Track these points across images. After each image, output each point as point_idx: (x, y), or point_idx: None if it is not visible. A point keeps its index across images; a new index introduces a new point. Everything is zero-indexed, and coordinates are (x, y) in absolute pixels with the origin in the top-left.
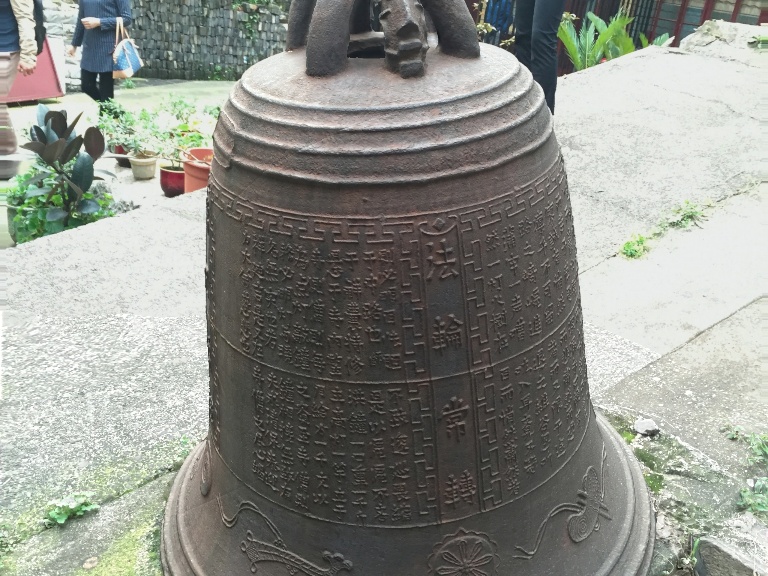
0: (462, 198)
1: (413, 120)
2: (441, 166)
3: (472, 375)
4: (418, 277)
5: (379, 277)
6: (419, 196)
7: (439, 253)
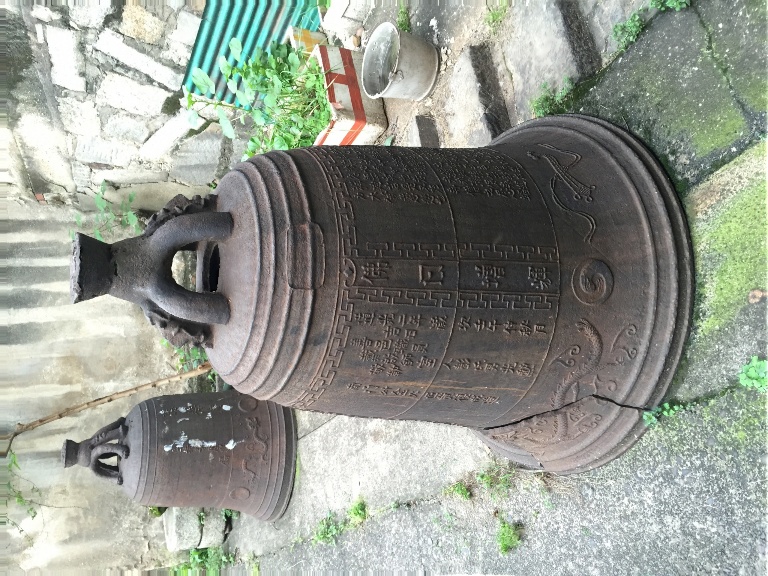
0: None
1: None
2: None
3: None
4: None
5: None
6: None
7: None
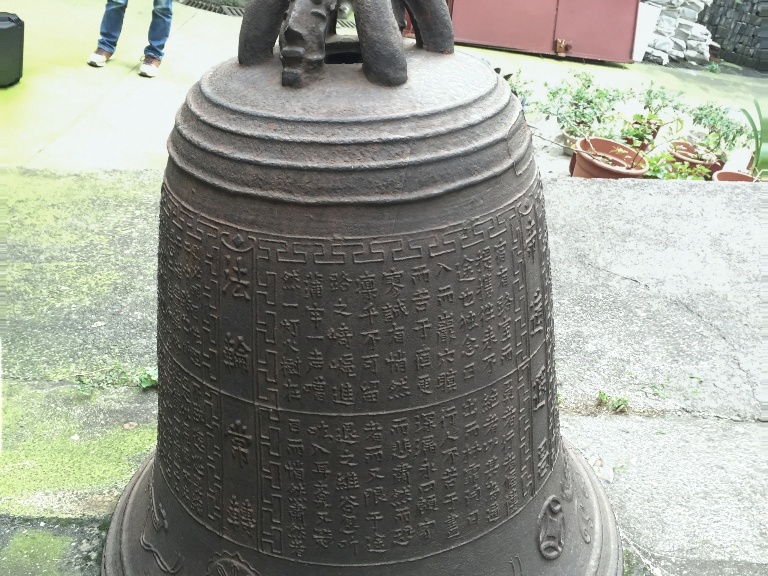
0: (267, 223)
1: (248, 128)
2: (252, 183)
3: (257, 408)
4: (216, 285)
5: (192, 270)
6: (228, 205)
7: (234, 269)
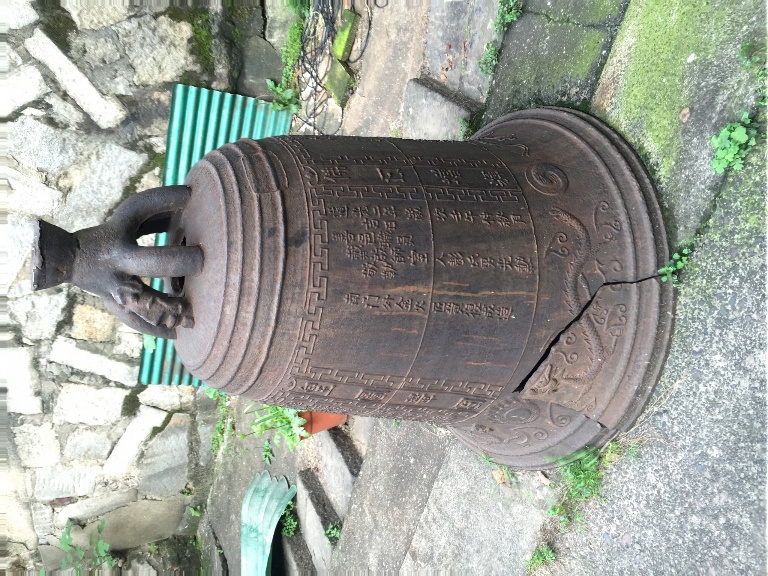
0: None
1: None
2: None
3: None
4: None
5: None
6: None
7: None
